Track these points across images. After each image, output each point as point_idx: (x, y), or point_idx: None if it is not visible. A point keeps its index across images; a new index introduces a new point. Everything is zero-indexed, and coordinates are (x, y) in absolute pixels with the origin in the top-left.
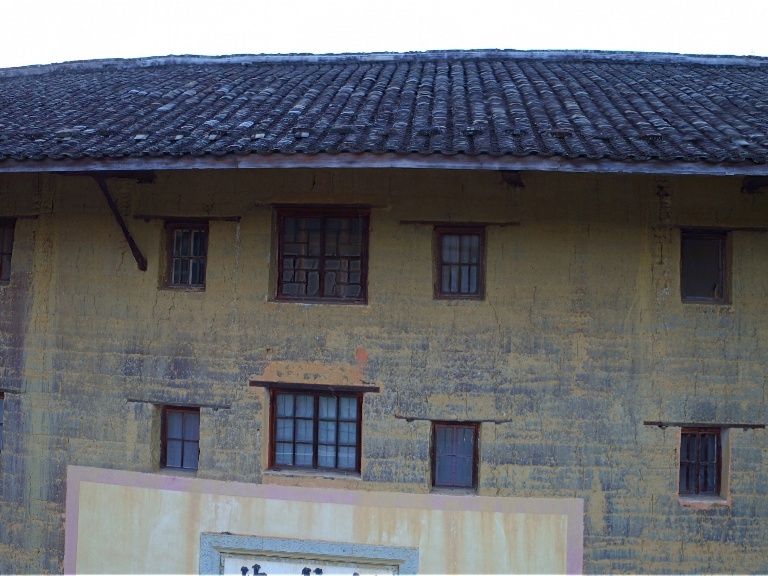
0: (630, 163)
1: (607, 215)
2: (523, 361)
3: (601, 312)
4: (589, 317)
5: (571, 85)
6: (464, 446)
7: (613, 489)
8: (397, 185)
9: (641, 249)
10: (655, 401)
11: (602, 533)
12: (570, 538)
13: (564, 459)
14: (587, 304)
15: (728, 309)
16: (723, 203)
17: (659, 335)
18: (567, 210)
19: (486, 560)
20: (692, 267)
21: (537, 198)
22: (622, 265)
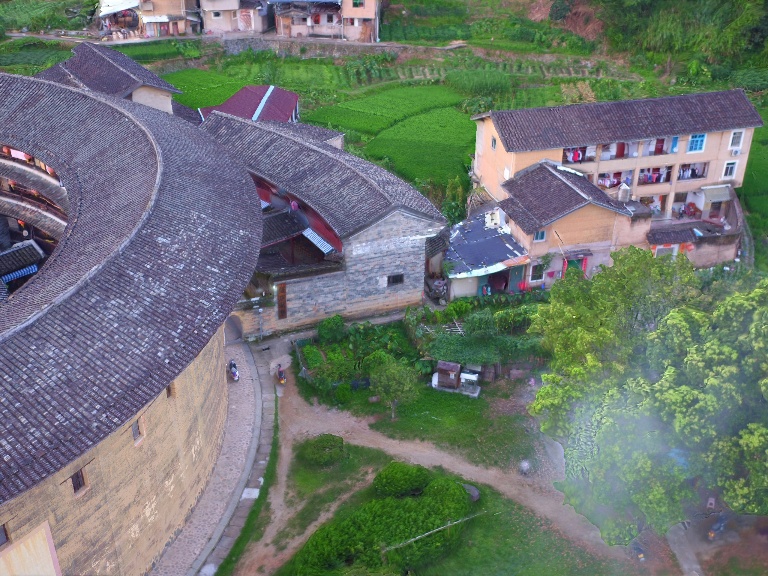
0: None
1: None
2: None
3: None
4: None
5: (7, 396)
6: (0, 531)
7: None
8: None
9: None
10: None
11: None
12: None
13: (38, 513)
14: None
15: None
16: None
17: None
18: None
19: None
20: None
21: None
22: None
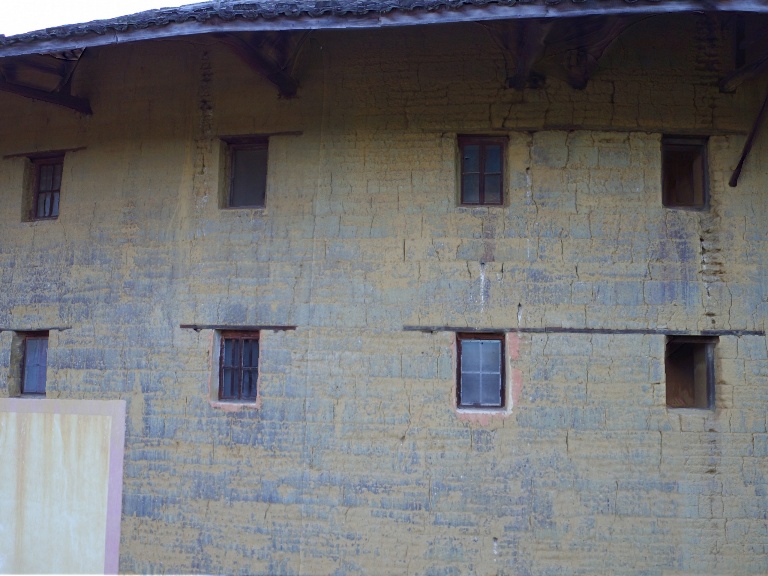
0: (2, 48)
1: (156, 132)
2: (82, 272)
3: (147, 222)
4: (137, 228)
5: None
6: None
7: (152, 391)
8: (4, 125)
9: (184, 161)
10: (191, 305)
11: (141, 434)
12: (113, 438)
13: (111, 362)
14: (136, 216)
15: (261, 212)
16: (260, 111)
17: (197, 241)
18: (124, 131)
19: (46, 459)
20: (243, 177)
21: (101, 123)
22: (167, 177)
